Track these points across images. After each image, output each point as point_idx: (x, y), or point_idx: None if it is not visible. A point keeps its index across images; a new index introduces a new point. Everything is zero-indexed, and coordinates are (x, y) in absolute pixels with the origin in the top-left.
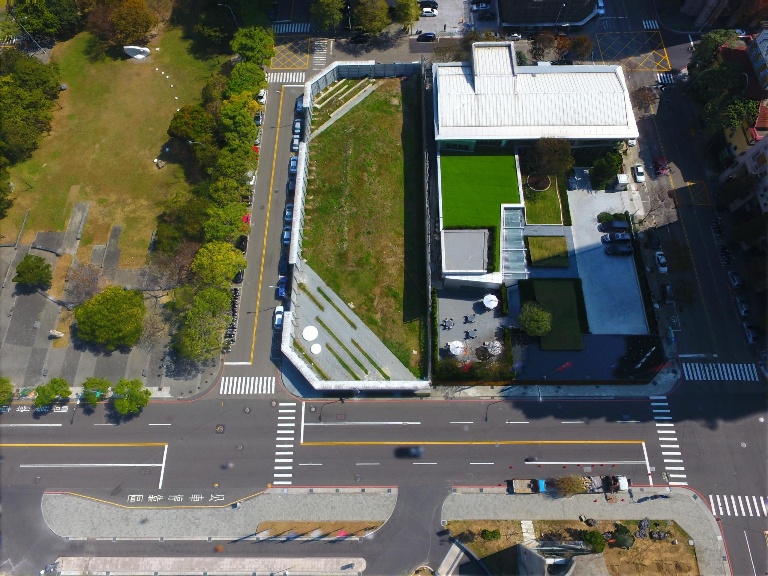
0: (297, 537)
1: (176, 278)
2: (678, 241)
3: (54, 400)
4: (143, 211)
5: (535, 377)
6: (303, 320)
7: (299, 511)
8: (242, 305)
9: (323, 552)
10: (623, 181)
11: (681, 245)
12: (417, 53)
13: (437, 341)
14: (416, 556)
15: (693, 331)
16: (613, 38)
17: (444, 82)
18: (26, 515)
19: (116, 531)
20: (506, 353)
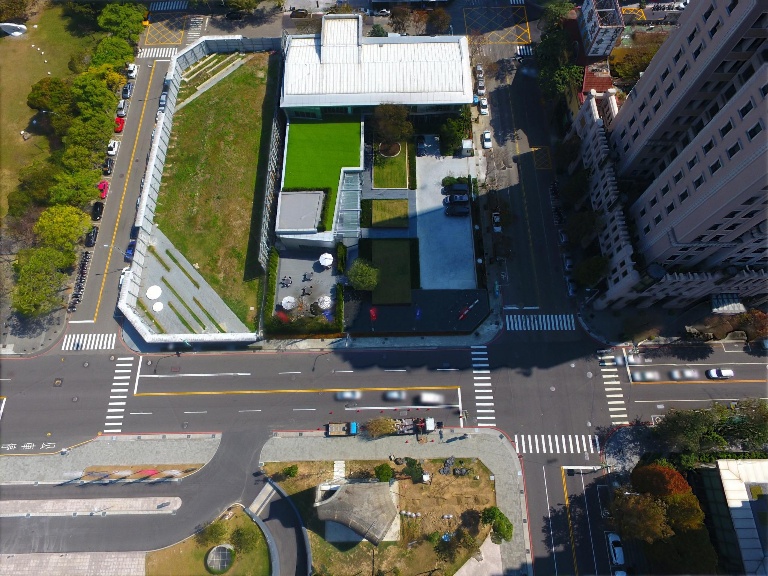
0: (119, 480)
1: (30, 243)
2: (516, 203)
3: None
4: (5, 180)
5: (364, 330)
6: (149, 280)
7: (125, 456)
8: (92, 267)
9: (142, 493)
10: (467, 146)
11: (503, 203)
12: (289, 28)
13: (273, 297)
14: (230, 495)
15: (519, 285)
16: (480, 13)
17: (294, 53)
18: None
19: None
20: (336, 307)
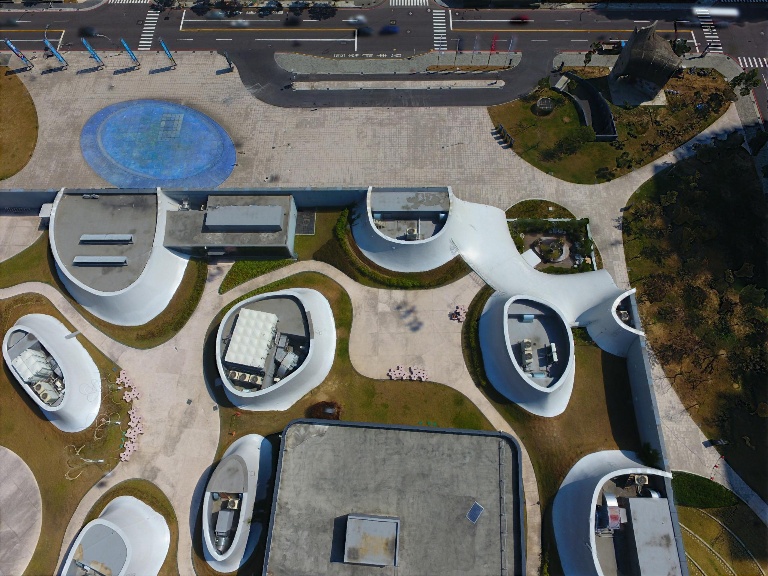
0: (455, 71)
1: None
2: None
3: (272, 8)
4: None
5: None
6: None
7: None
8: None
9: (474, 78)
10: None
11: None
12: None
13: None
14: None
15: None
16: None
17: None
18: (265, 63)
19: (330, 69)
20: None
